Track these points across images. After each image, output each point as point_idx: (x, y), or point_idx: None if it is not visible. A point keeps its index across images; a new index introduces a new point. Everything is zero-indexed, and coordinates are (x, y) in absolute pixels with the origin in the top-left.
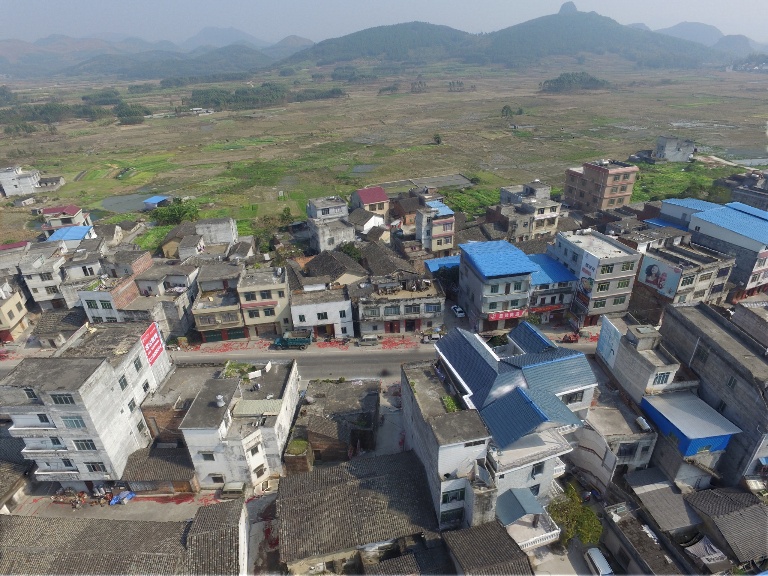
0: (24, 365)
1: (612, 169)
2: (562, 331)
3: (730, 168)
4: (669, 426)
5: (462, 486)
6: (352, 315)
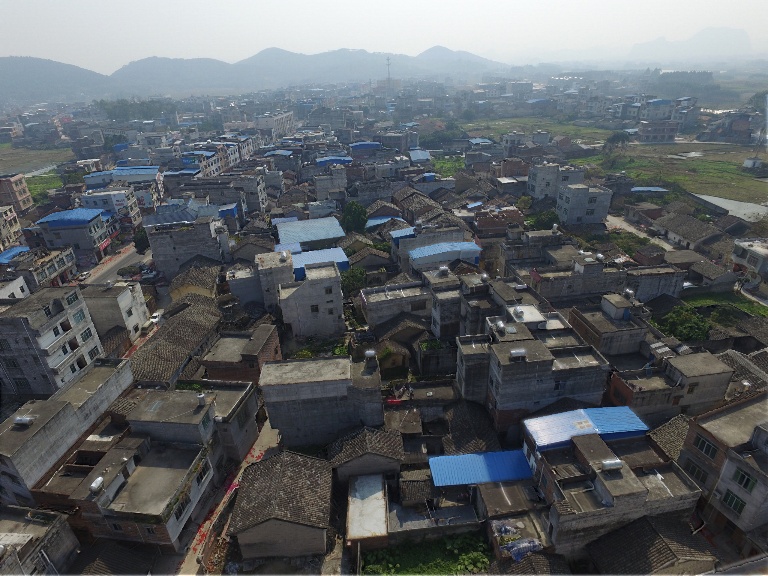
0: (6, 315)
1: (10, 178)
2: (129, 243)
3: (31, 179)
4: (224, 212)
5: (219, 239)
6: (28, 287)
